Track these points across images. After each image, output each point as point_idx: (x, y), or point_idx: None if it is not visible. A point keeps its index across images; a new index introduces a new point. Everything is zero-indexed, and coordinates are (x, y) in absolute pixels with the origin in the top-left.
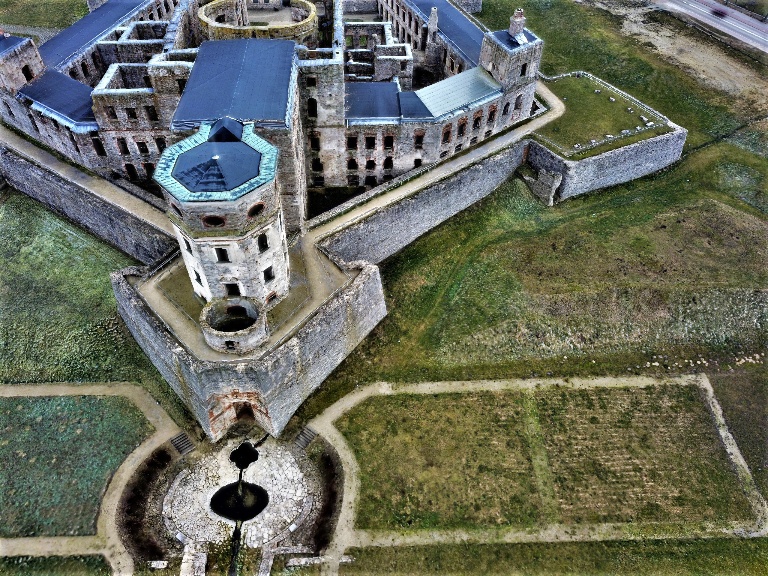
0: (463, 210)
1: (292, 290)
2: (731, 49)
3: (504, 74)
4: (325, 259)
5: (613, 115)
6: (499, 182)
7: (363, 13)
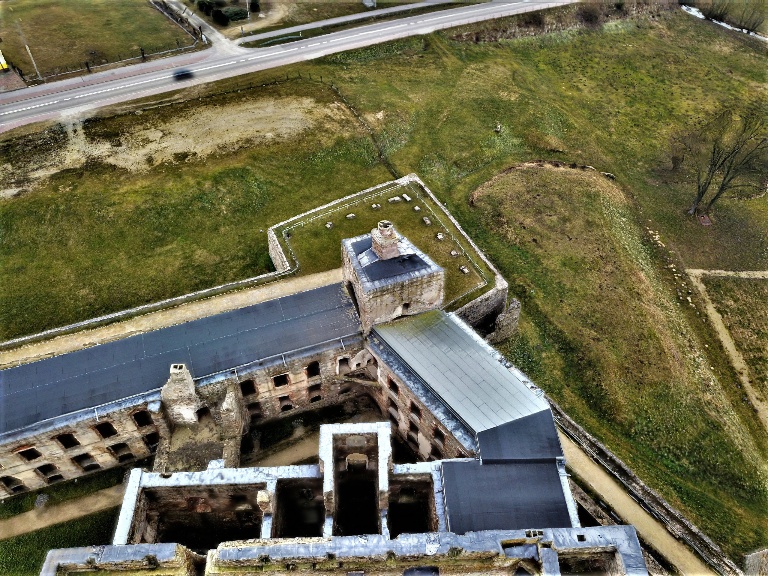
0: None
1: None
2: (208, 99)
3: (438, 295)
4: None
5: None
6: None
7: None
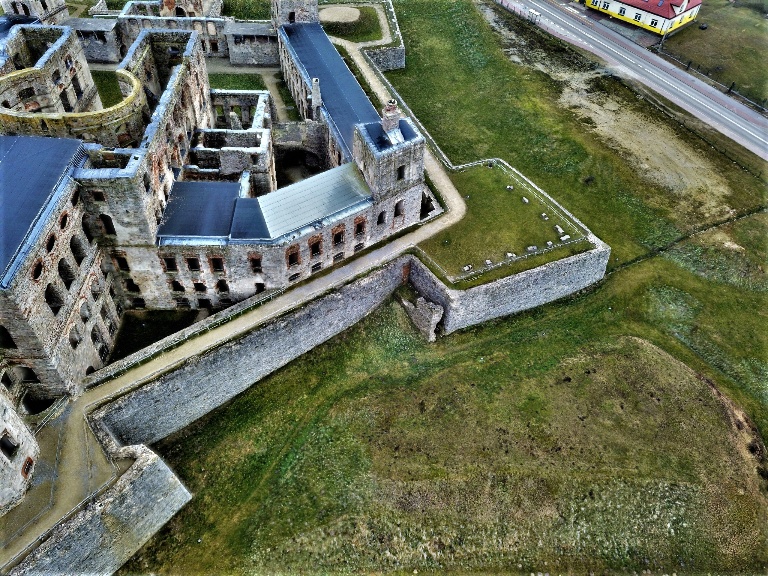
0: (321, 344)
1: (31, 491)
2: (684, 130)
3: (373, 180)
4: (92, 440)
5: (522, 223)
6: (371, 307)
7: (264, 66)
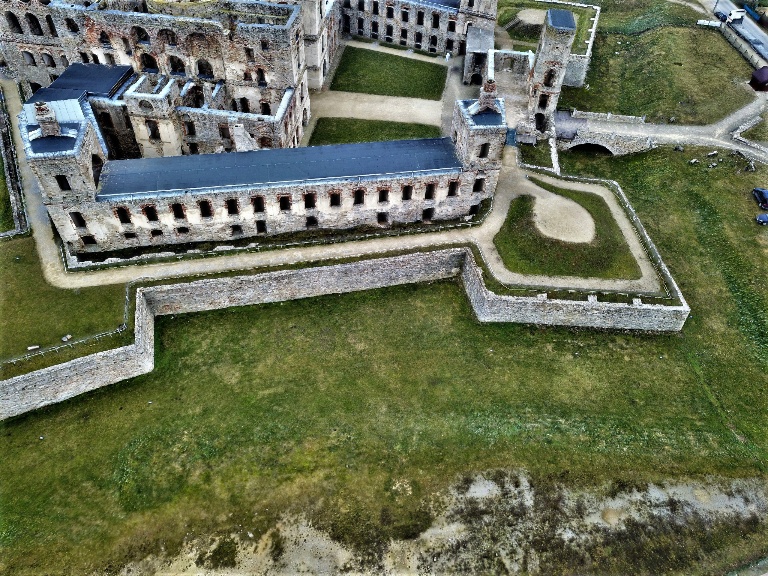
0: None
1: None
2: None
3: None
4: None
5: None
6: None
7: None
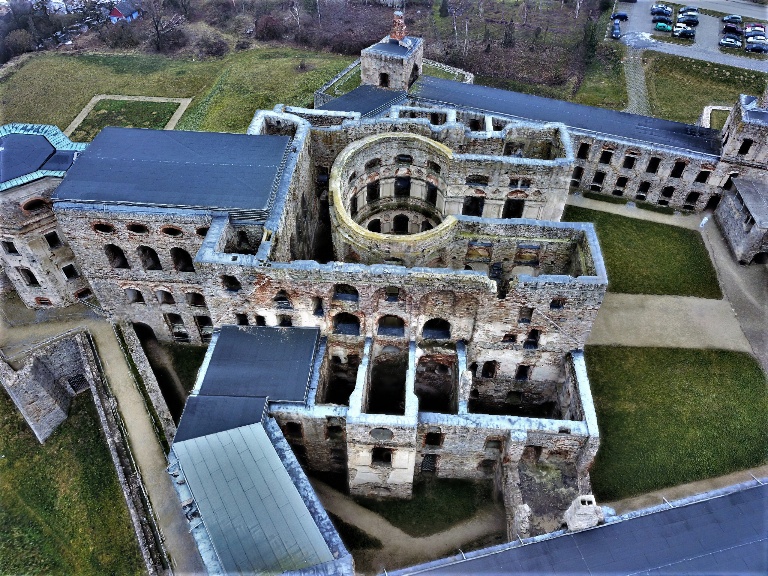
0: None
1: (33, 311)
2: None
3: None
4: None
5: None
6: None
7: None
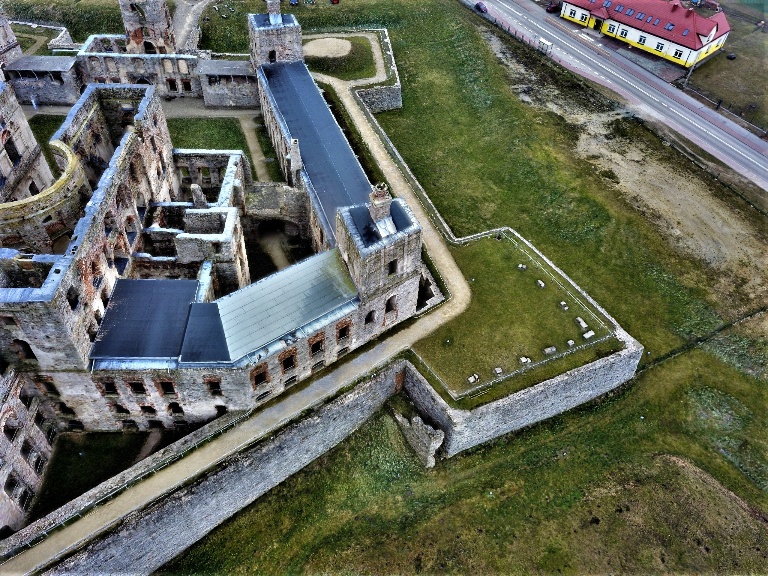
0: (296, 473)
1: None
2: (718, 184)
3: (359, 279)
4: None
5: (538, 314)
6: (358, 423)
7: (243, 108)
